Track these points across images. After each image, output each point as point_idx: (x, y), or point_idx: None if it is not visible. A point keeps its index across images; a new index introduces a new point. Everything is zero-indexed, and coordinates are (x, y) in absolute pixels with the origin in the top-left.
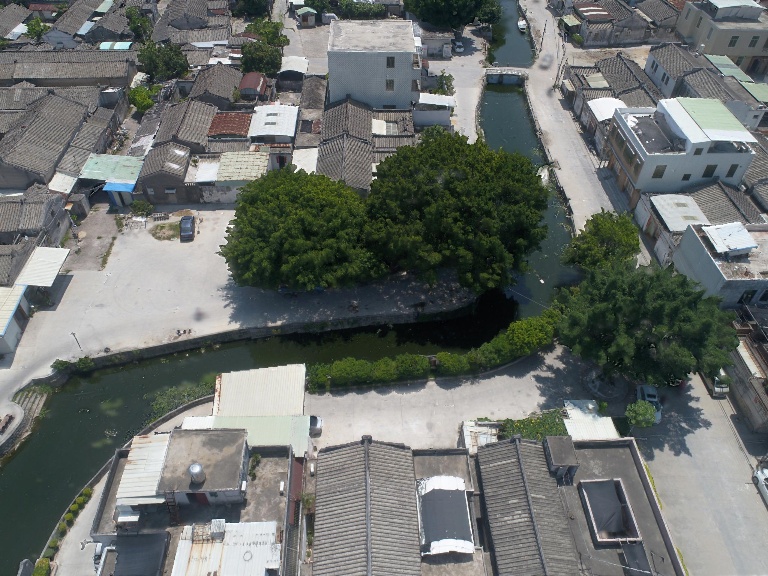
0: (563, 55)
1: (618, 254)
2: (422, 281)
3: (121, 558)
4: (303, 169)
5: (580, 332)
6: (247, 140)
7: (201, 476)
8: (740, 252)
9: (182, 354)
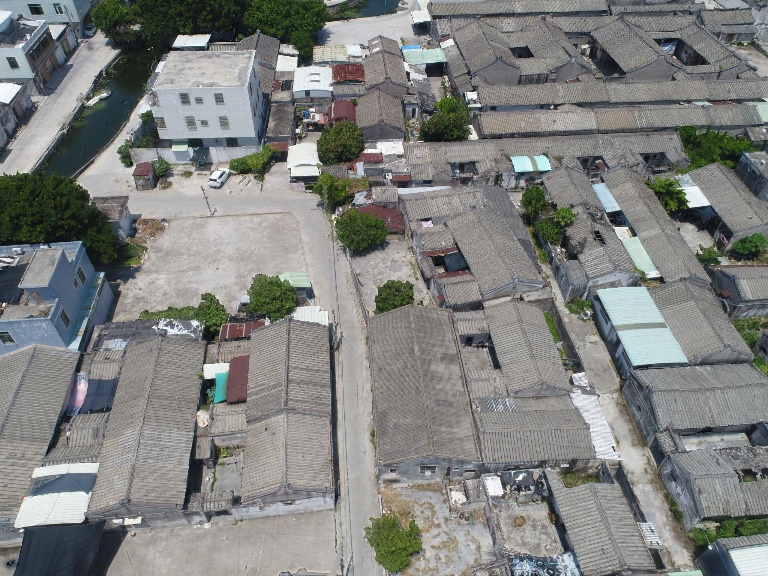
0: None
1: None
2: None
3: None
4: (281, 8)
5: None
6: None
7: None
8: None
9: None
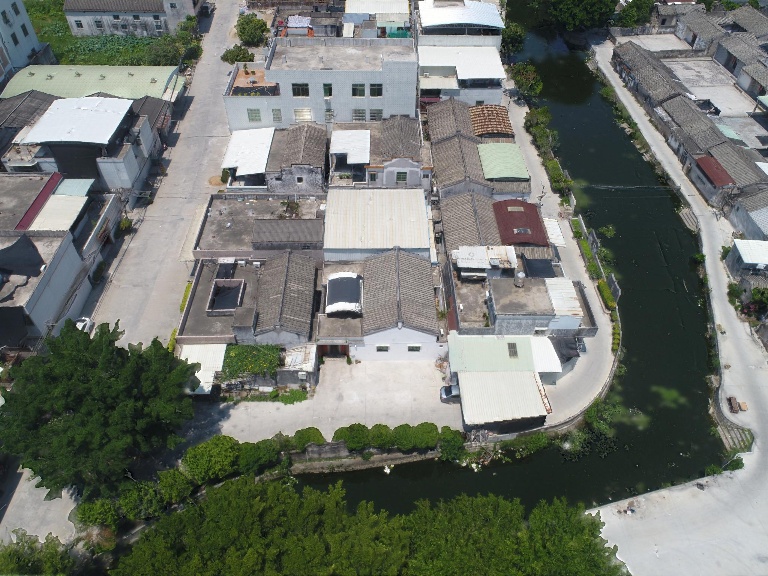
0: None
1: (58, 480)
2: None
3: None
4: None
5: None
6: None
7: None
8: None
9: None
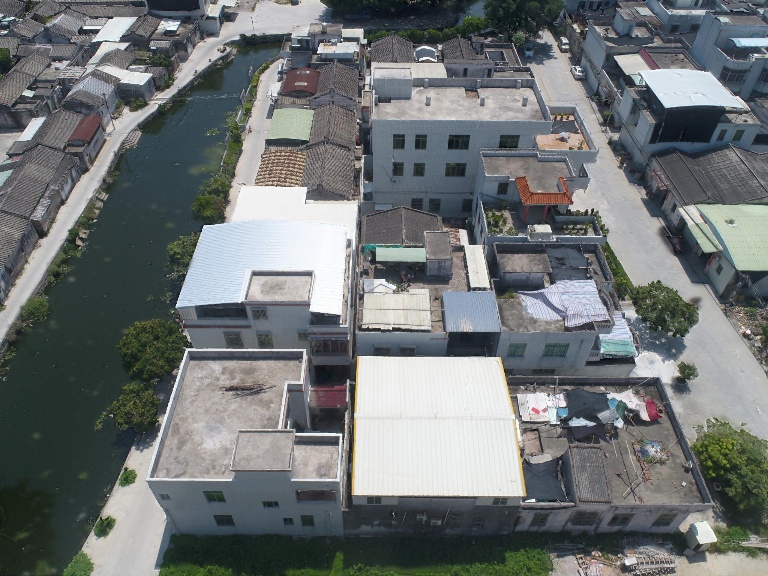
0: None
1: None
2: (422, 19)
3: (294, 58)
4: None
5: (491, 2)
6: None
7: (326, 29)
8: None
9: None
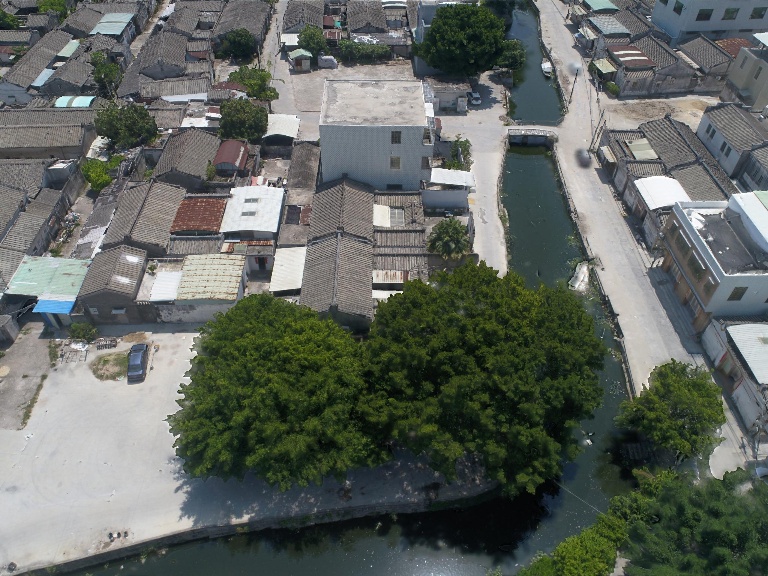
0: (601, 117)
1: (707, 451)
2: None
3: None
4: (282, 301)
5: None
6: (218, 238)
7: None
8: None
9: (115, 565)
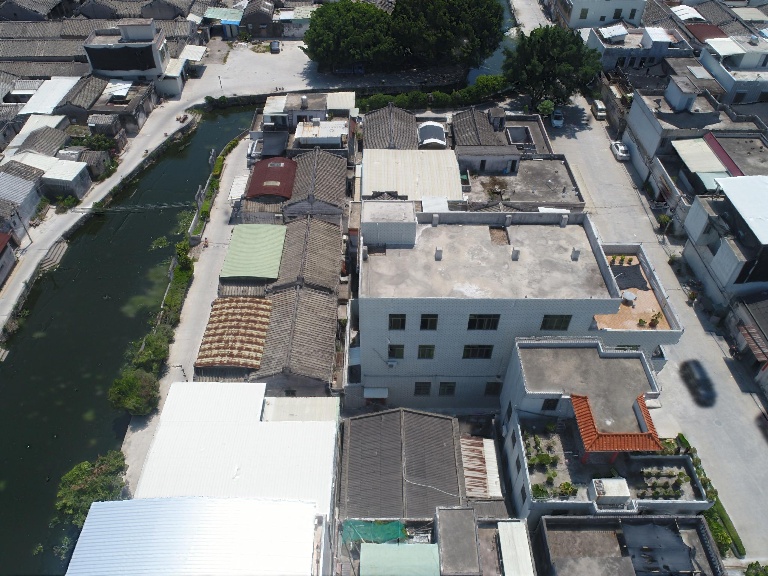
0: None
1: None
2: (426, 73)
3: (266, 141)
4: None
5: (512, 62)
6: (311, 0)
7: (306, 103)
8: (618, 38)
9: None
